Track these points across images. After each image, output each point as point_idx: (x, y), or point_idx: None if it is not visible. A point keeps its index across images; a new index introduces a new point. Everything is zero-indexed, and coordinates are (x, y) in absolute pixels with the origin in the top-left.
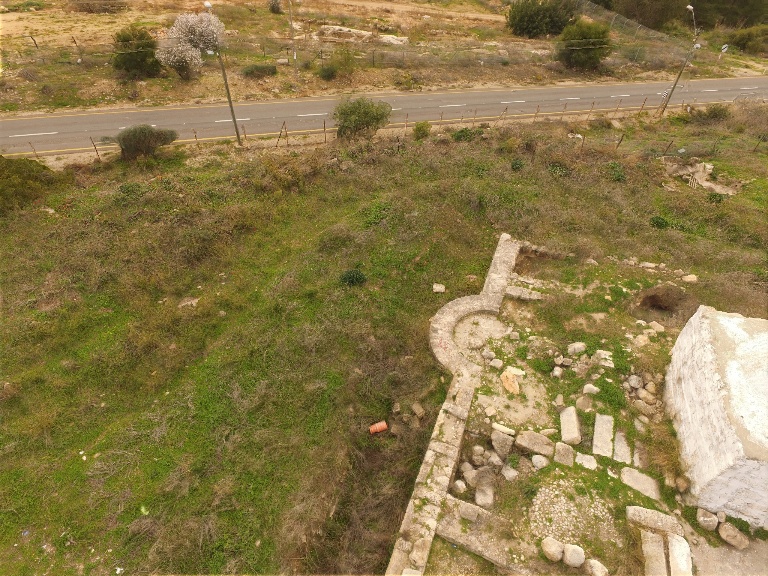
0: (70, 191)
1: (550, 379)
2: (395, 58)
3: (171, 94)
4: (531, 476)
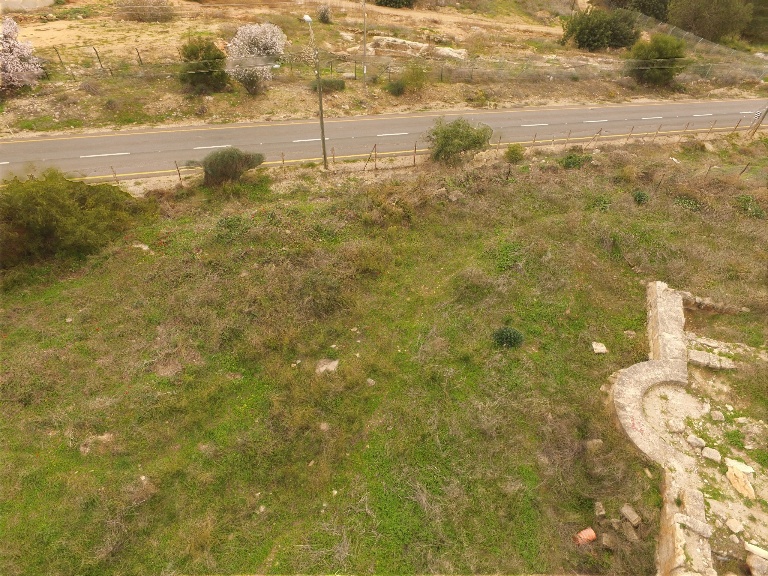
0: (159, 223)
1: None
2: (463, 73)
3: (239, 110)
4: None
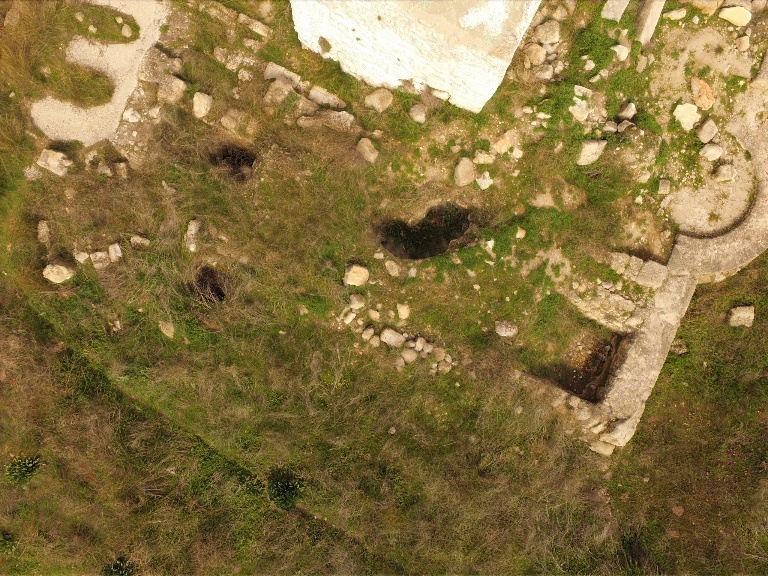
0: None
1: (638, 105)
2: None
3: None
4: None
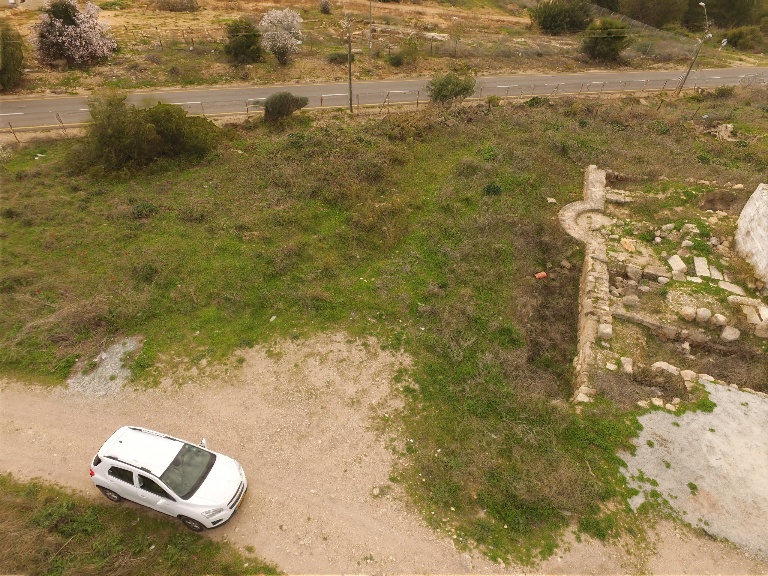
0: None
1: (653, 245)
2: (449, 49)
3: (274, 76)
4: (660, 288)
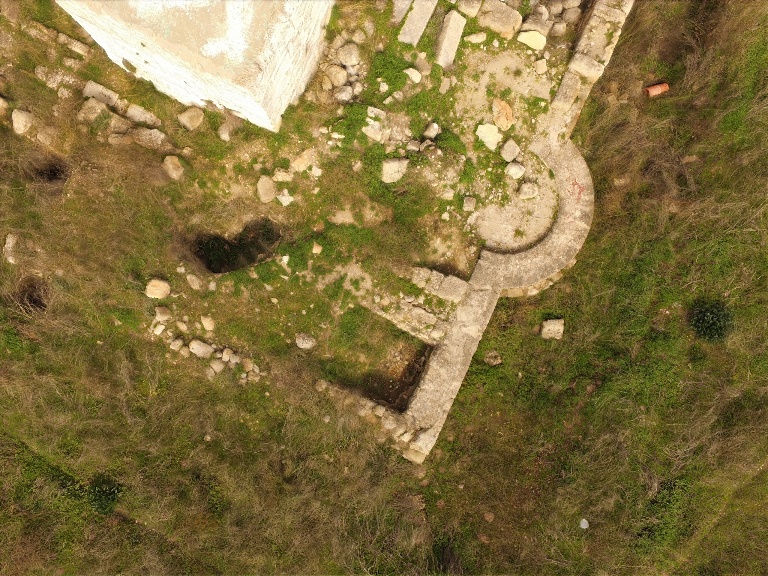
0: None
1: (443, 125)
2: None
3: None
4: None
